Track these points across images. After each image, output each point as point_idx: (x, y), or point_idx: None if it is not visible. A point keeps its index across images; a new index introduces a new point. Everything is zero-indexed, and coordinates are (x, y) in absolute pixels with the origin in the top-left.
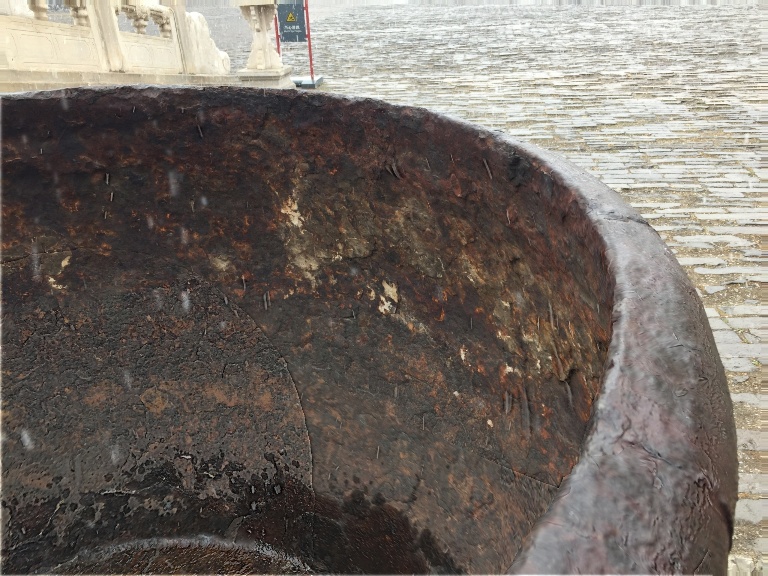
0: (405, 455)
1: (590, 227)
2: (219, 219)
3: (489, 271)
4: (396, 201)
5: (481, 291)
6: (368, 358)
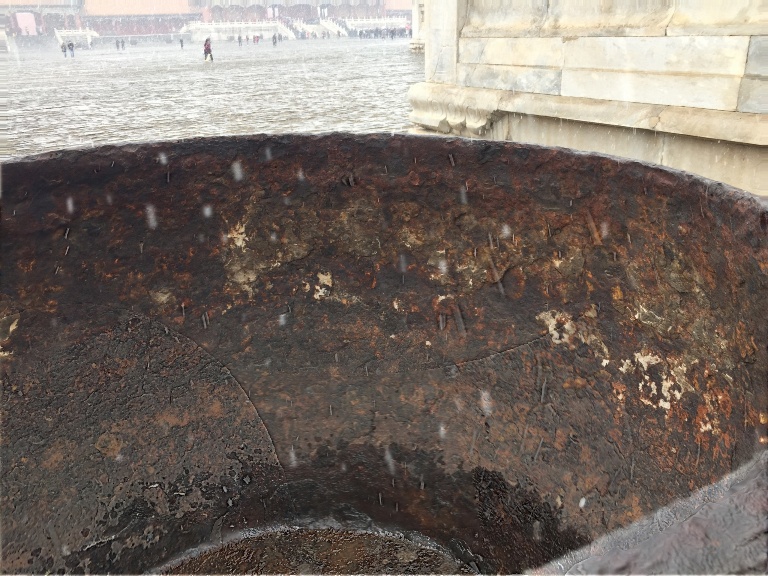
0: (356, 401)
1: (583, 157)
2: (165, 255)
3: (428, 233)
4: (342, 205)
5: (416, 251)
6: (307, 340)
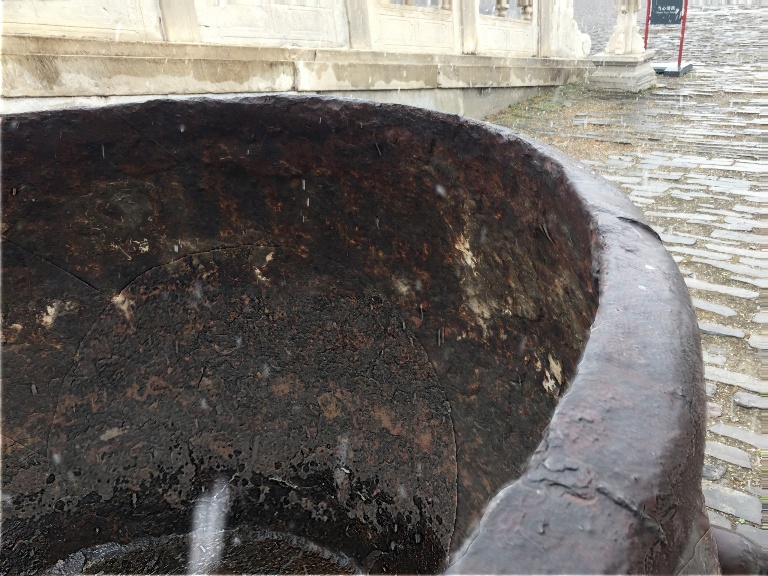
0: None
1: None
2: (401, 241)
3: None
4: (555, 268)
5: None
6: (527, 435)
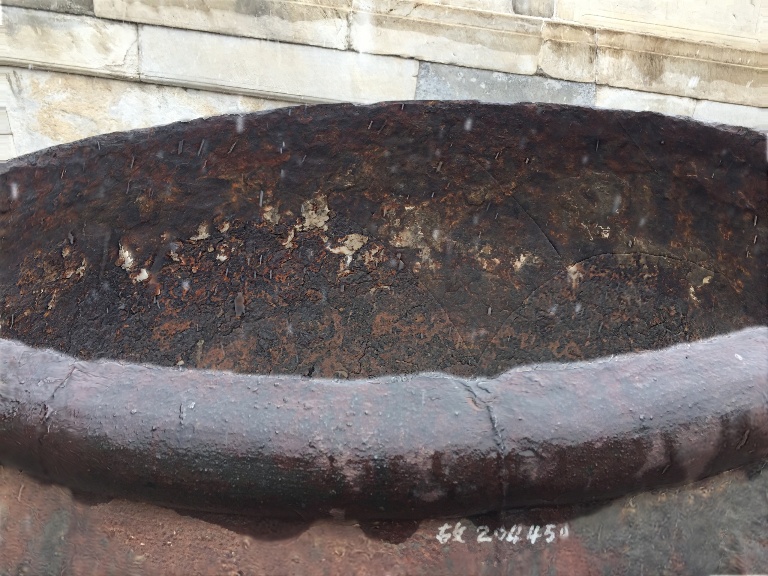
0: None
1: None
2: None
3: None
4: None
5: None
6: None
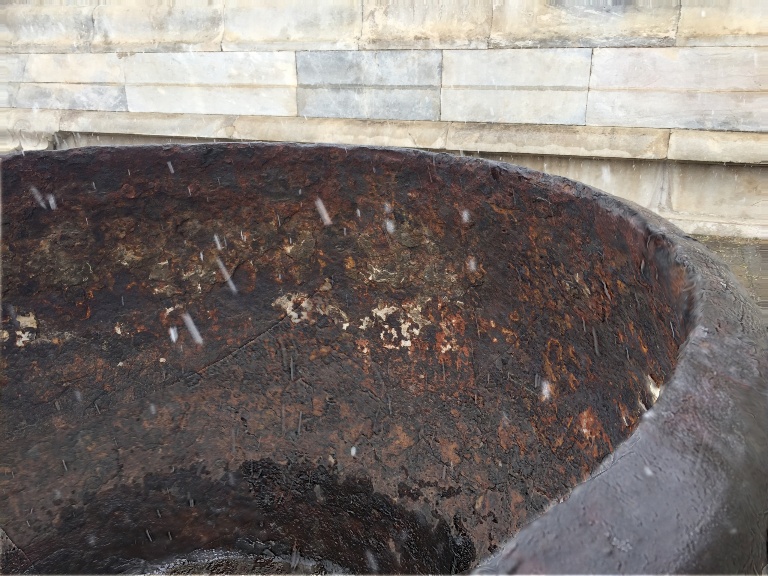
0: (93, 445)
1: (310, 149)
2: None
3: (148, 246)
4: (42, 233)
5: (135, 268)
6: (16, 397)
